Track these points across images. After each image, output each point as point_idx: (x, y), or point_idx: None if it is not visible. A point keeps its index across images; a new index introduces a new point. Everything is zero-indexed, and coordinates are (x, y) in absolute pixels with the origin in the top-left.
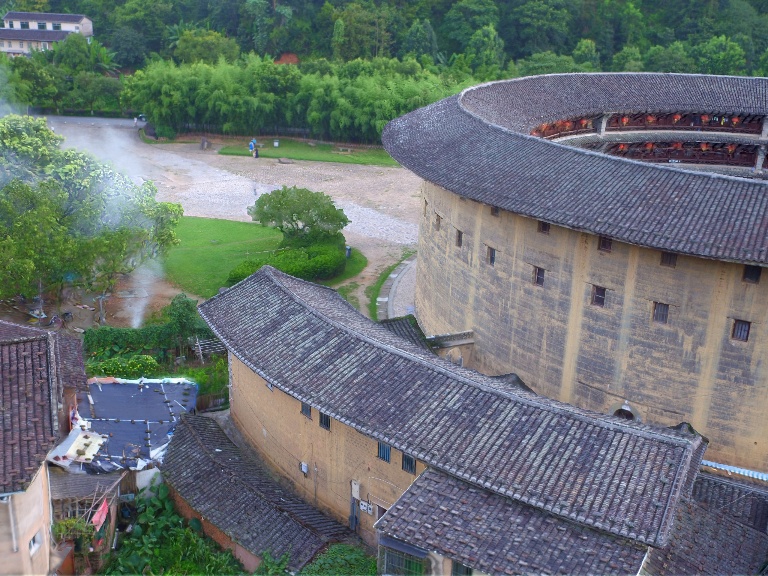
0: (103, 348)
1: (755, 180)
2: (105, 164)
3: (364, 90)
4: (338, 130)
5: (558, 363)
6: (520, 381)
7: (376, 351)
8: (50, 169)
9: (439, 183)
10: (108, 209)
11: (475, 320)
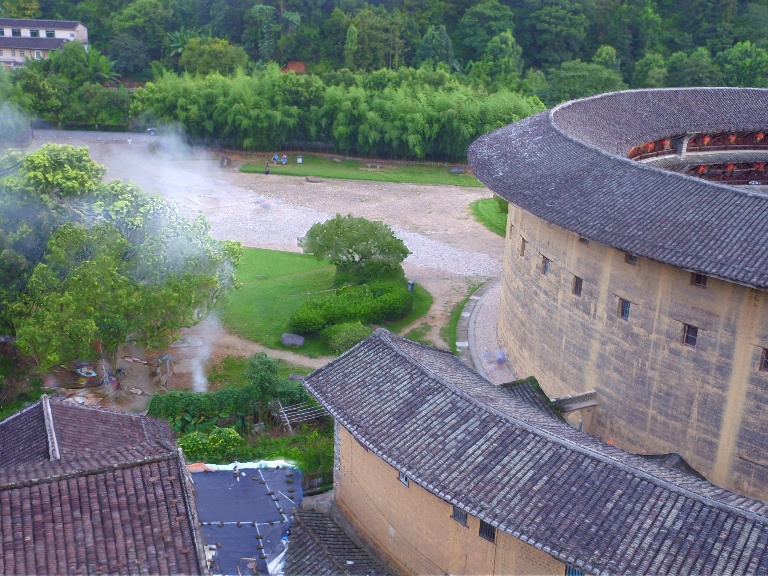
0: (172, 417)
1: None
2: (153, 197)
3: (393, 103)
4: (366, 145)
5: (712, 435)
6: (685, 463)
7: (552, 447)
8: (99, 207)
9: (570, 227)
10: (169, 253)
11: (599, 379)
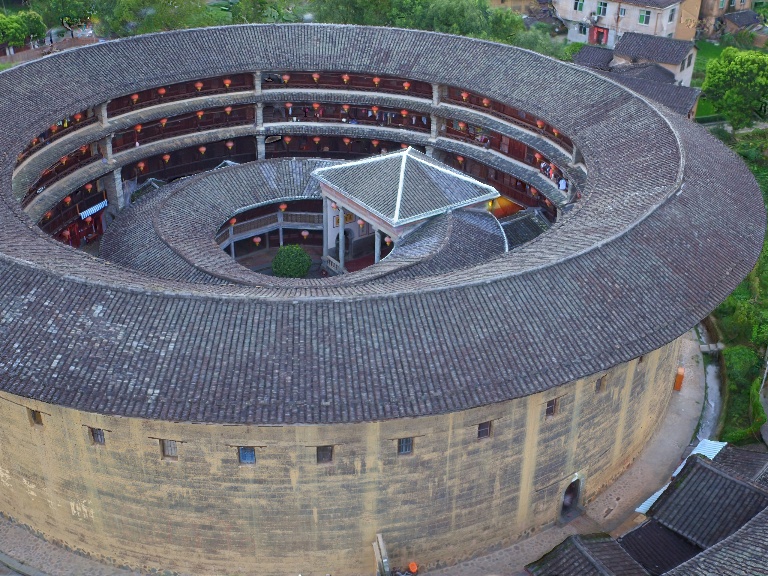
0: None
1: (621, 233)
2: None
3: None
4: None
5: None
6: (583, 537)
7: None
8: None
9: (397, 416)
10: None
11: (384, 522)
